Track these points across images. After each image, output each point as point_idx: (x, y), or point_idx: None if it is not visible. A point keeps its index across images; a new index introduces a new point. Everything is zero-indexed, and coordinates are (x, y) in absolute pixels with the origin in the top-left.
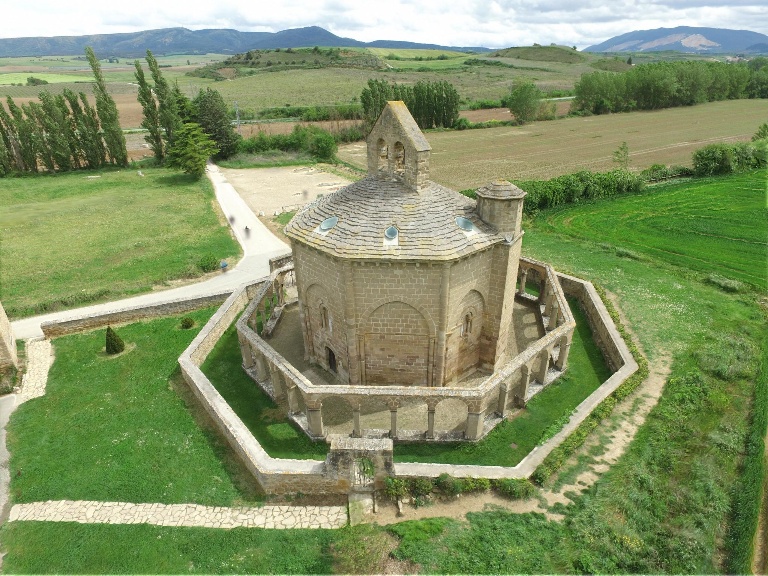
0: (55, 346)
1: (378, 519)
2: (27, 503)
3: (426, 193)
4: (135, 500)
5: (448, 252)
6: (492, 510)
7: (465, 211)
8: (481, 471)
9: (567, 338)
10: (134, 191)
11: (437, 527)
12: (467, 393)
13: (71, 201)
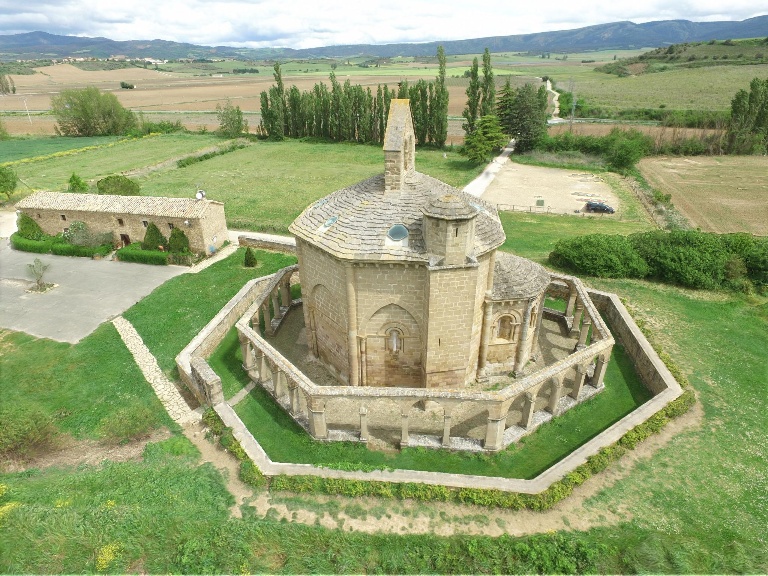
0: (236, 251)
1: (188, 429)
2: (124, 318)
3: (393, 195)
4: (145, 341)
5: (347, 251)
6: (221, 473)
7: (416, 222)
8: (251, 445)
9: (488, 410)
10: (421, 168)
11: (178, 450)
12: (303, 385)
13: (375, 167)
